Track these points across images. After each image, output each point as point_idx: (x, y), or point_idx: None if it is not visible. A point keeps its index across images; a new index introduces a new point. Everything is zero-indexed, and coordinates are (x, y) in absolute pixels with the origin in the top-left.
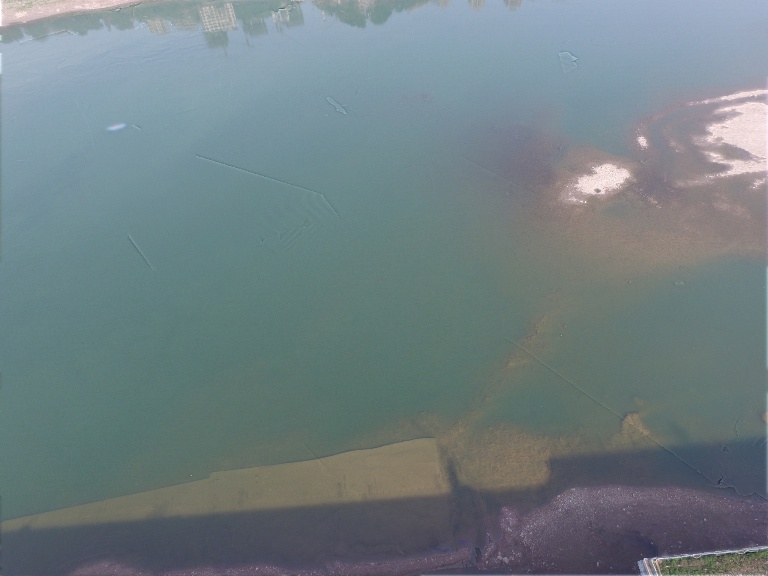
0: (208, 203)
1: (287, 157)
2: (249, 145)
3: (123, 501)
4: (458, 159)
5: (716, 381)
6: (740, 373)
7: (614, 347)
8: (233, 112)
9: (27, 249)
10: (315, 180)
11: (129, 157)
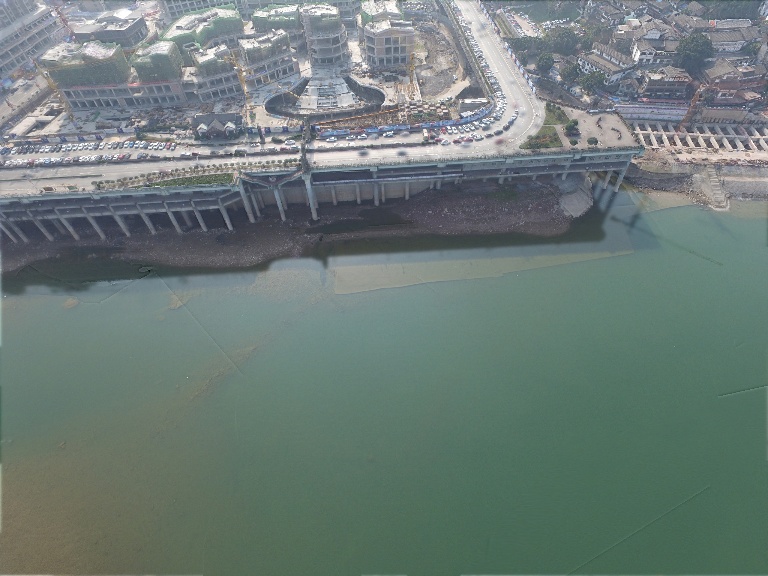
0: (629, 467)
1: None
2: None
3: (558, 262)
4: None
5: (79, 341)
6: (52, 346)
7: (144, 365)
8: None
9: None
10: None
11: (766, 424)
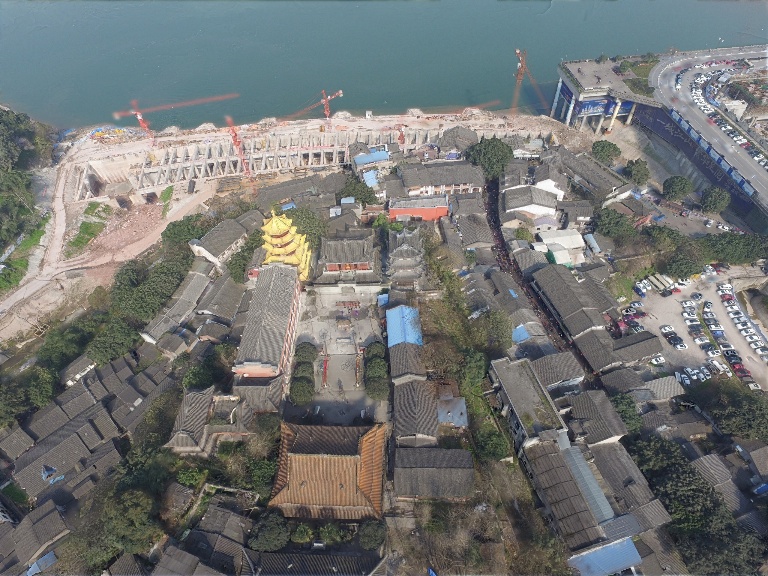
0: None
1: None
2: None
3: None
4: None
5: None
6: None
7: None
8: None
9: None
10: None
11: None
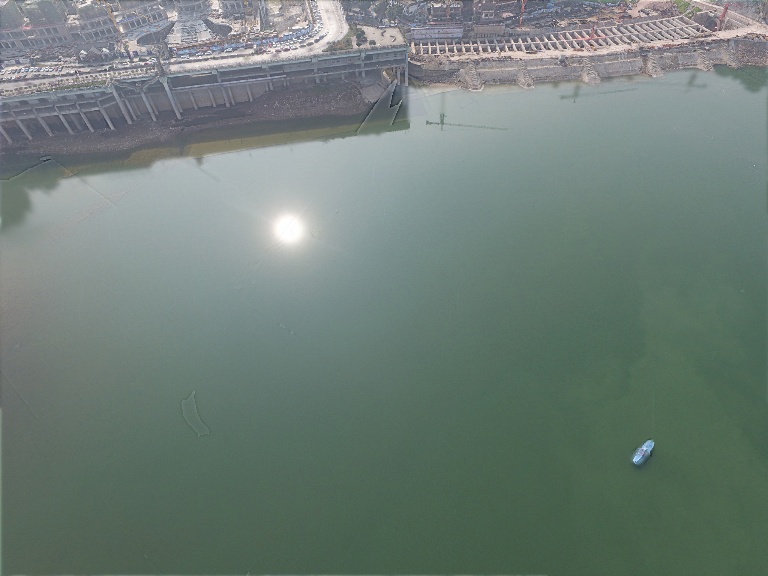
0: None
1: (314, 419)
2: (376, 425)
3: (354, 128)
4: (43, 410)
5: None
6: None
7: (44, 209)
8: (428, 500)
9: (542, 230)
10: (262, 353)
11: None
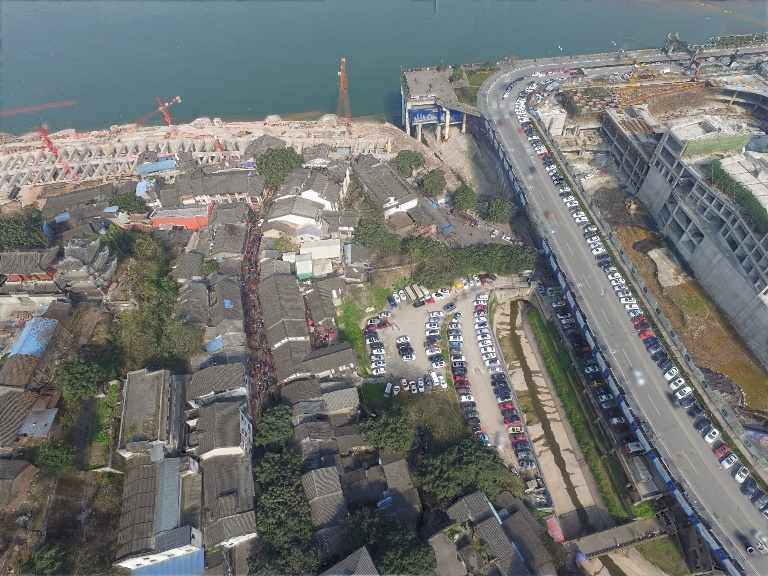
0: None
1: None
2: None
3: None
4: None
5: None
6: None
7: None
8: None
9: None
10: None
11: None
